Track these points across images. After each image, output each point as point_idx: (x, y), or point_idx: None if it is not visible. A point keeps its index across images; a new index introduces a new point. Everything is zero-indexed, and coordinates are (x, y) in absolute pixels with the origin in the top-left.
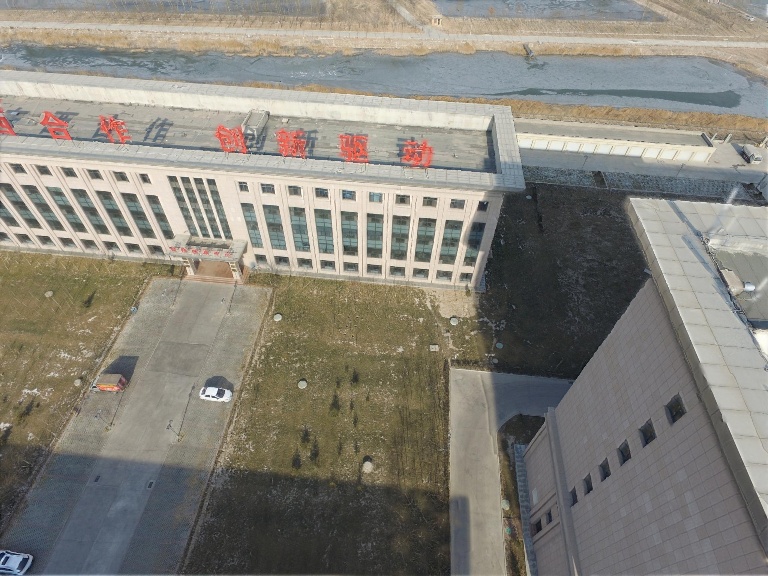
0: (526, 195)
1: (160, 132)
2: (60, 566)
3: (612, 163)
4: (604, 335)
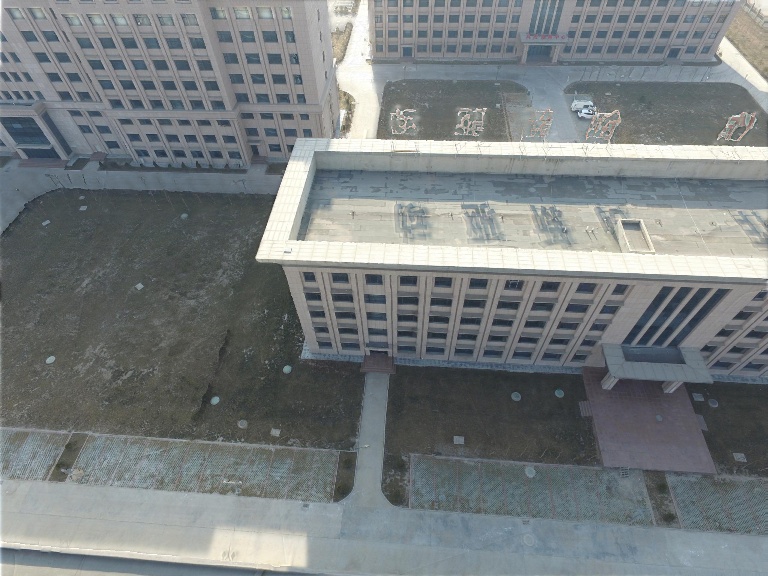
0: (217, 405)
1: (751, 228)
2: (565, 118)
3: (4, 513)
4: (231, 226)
